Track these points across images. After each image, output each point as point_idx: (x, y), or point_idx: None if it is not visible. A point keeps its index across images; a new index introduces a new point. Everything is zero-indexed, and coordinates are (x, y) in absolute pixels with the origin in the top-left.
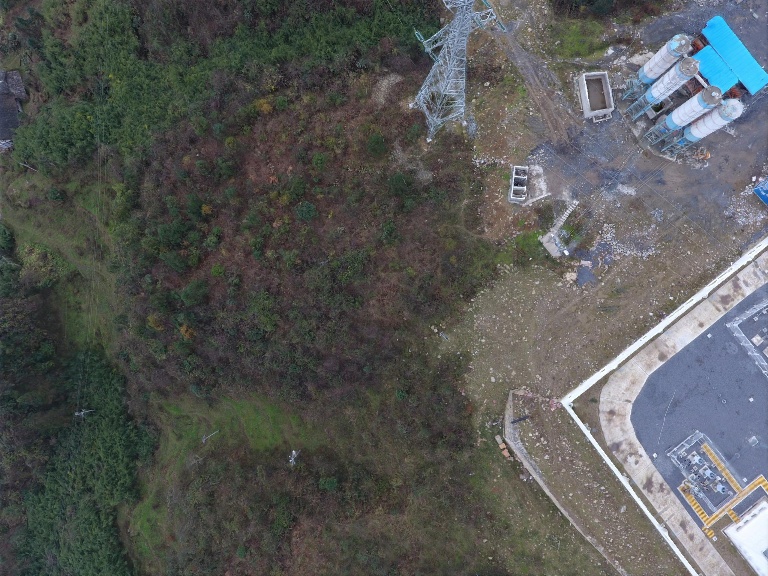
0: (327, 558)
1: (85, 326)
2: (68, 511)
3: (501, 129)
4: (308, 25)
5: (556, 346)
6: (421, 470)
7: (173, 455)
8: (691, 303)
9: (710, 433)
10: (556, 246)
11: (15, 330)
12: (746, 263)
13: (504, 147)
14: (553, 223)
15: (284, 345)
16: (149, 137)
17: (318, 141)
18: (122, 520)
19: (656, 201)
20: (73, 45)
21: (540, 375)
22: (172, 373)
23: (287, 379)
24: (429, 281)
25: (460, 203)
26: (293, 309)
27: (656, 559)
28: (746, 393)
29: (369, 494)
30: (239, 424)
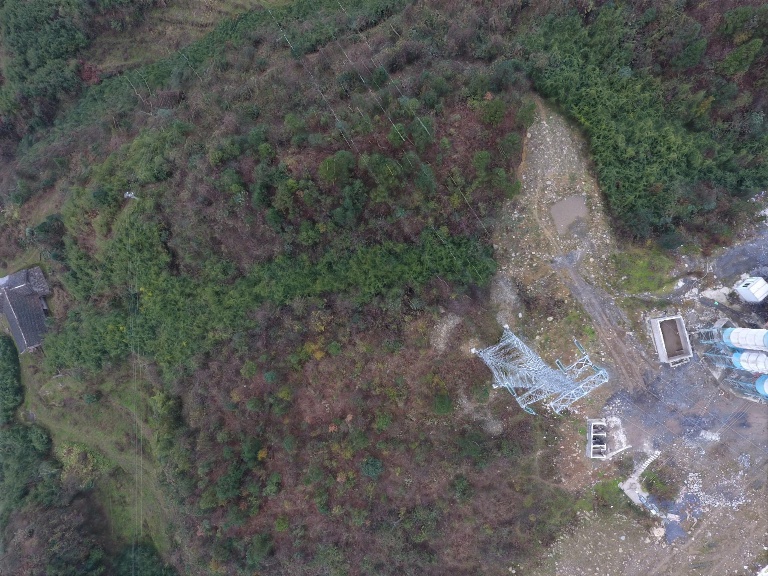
0: None
1: (131, 519)
2: None
3: None
4: (353, 256)
5: None
6: None
7: None
8: None
9: None
10: None
11: (65, 550)
12: None
13: None
14: (633, 469)
15: None
16: (189, 356)
17: (377, 390)
18: None
19: (742, 445)
20: (99, 259)
21: None
22: None
23: None
24: (507, 537)
25: (534, 454)
26: (364, 562)
27: None
28: None
29: None
30: None
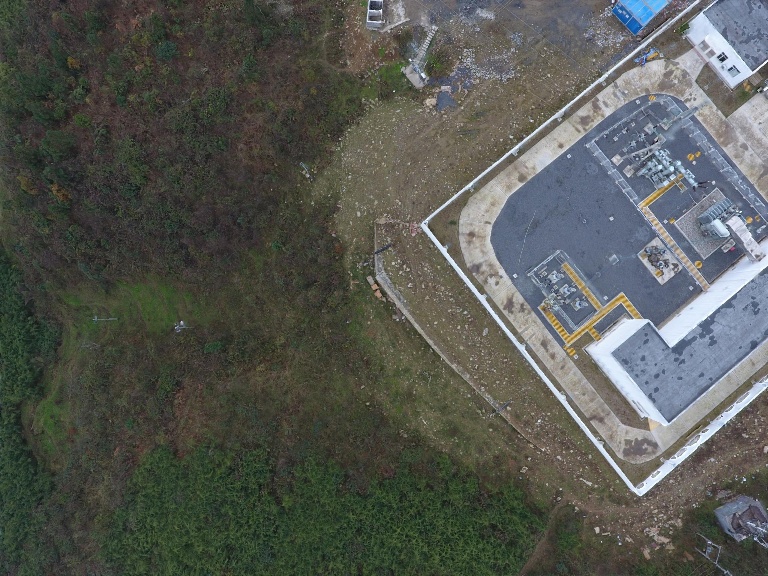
0: (208, 416)
1: None
2: None
3: None
4: None
5: (415, 170)
6: (301, 324)
7: (75, 350)
8: (547, 120)
9: (571, 253)
10: None
11: None
12: (606, 84)
13: None
14: (415, 53)
15: (153, 195)
16: (25, 6)
17: None
18: (26, 419)
19: (516, 25)
20: None
21: (399, 200)
22: (58, 250)
23: (166, 240)
24: (292, 116)
25: (321, 36)
26: (160, 156)
27: (519, 381)
28: (606, 212)
29: (254, 356)
30: (137, 310)
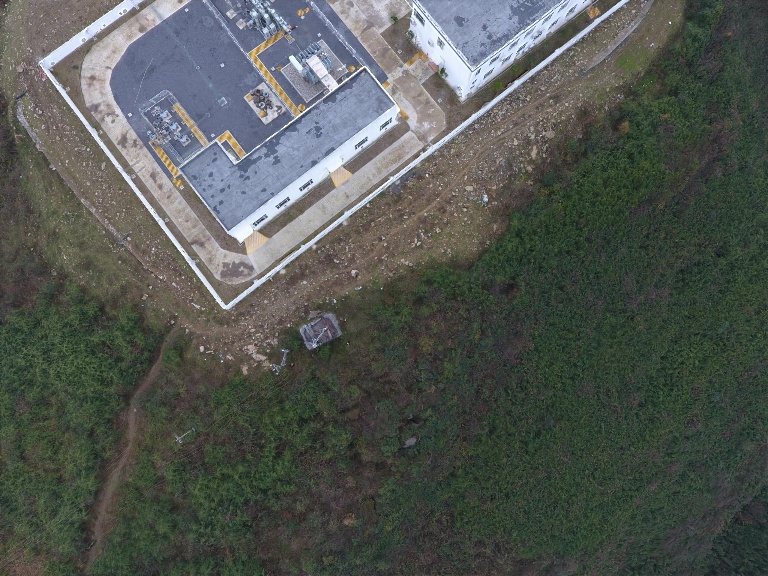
0: None
1: None
2: None
3: None
4: None
5: (46, 22)
6: None
7: None
8: None
9: (183, 95)
10: None
11: None
12: None
13: None
14: None
15: None
16: None
17: None
18: None
19: None
20: None
21: (31, 48)
22: None
23: None
24: None
25: None
26: None
27: (133, 210)
28: (219, 60)
29: None
30: None
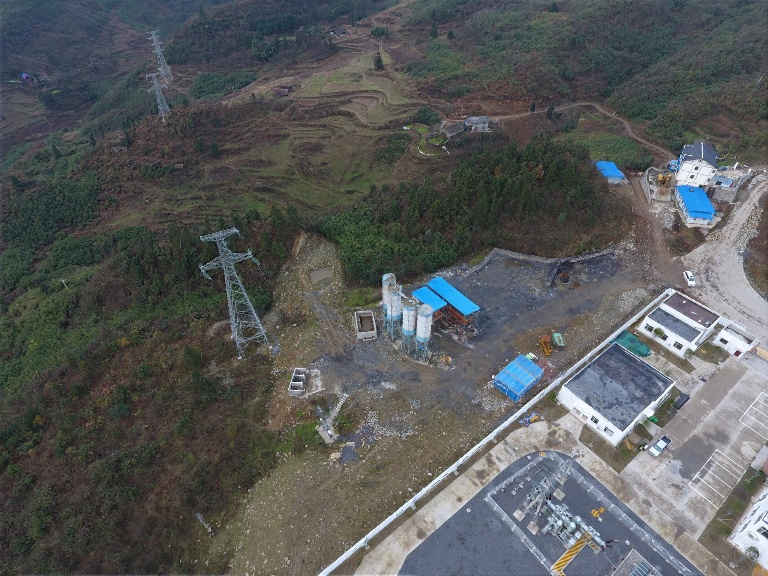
0: None
1: None
2: None
3: (294, 347)
4: (181, 298)
5: (310, 523)
6: None
7: None
8: None
9: None
10: None
11: None
12: (496, 441)
13: (293, 358)
14: (329, 415)
15: (41, 550)
16: None
17: (153, 362)
18: None
19: (414, 394)
20: (16, 323)
21: (289, 558)
22: None
23: None
24: (207, 468)
25: (252, 401)
26: (68, 506)
27: None
28: None
29: None
30: None
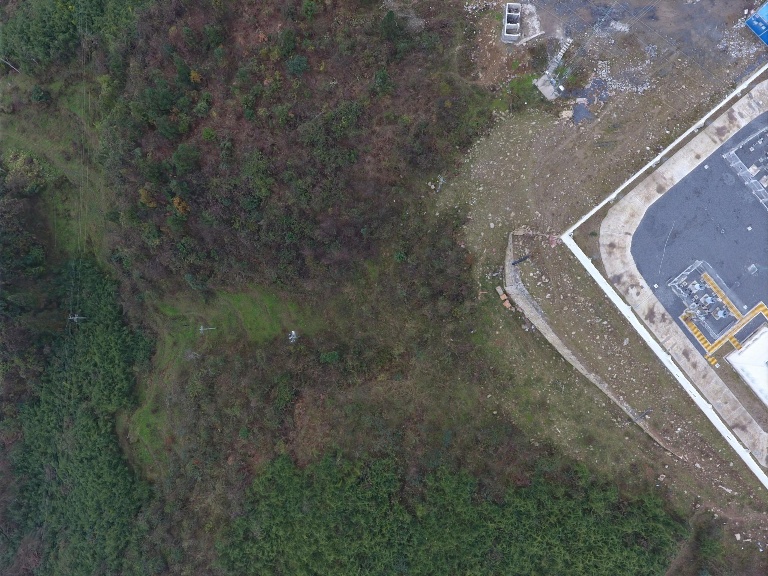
0: (331, 426)
1: (75, 234)
2: (65, 422)
3: None
4: None
5: (554, 182)
6: (422, 333)
7: (170, 359)
8: None
9: (710, 263)
10: (551, 88)
11: (3, 229)
12: (741, 95)
13: None
14: (547, 65)
15: (280, 207)
16: (133, 19)
17: None
18: (121, 428)
19: (650, 37)
20: None
21: (539, 212)
22: (166, 261)
23: (284, 251)
24: (425, 129)
25: (453, 49)
26: (288, 169)
27: (660, 390)
28: (744, 222)
29: (371, 365)
30: (236, 319)
